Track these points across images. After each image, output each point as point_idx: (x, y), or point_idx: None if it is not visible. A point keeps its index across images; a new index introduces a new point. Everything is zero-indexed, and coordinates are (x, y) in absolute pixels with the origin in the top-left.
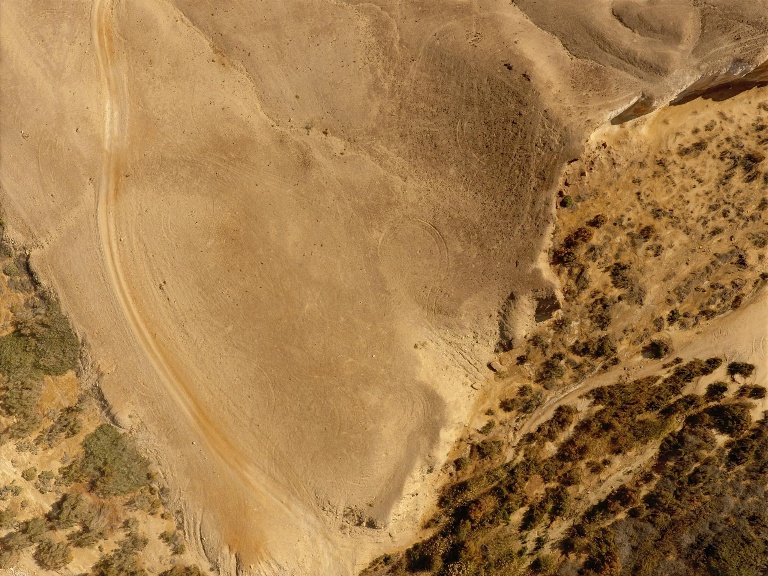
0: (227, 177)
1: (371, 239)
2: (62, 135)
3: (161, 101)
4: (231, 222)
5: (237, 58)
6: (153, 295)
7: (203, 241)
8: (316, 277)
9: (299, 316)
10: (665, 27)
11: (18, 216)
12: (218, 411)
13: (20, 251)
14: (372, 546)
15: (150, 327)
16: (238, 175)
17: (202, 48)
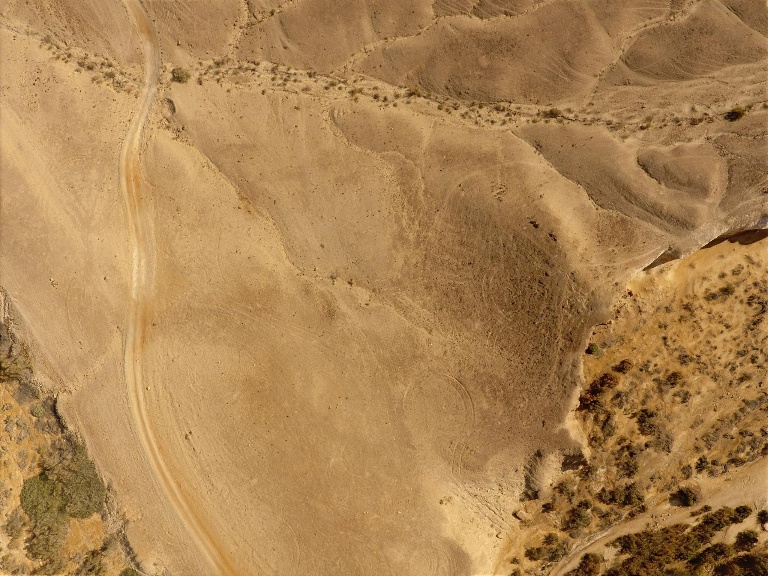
0: (253, 327)
1: (396, 392)
2: (90, 283)
3: (188, 249)
4: (257, 374)
5: (263, 205)
6: (179, 444)
7: (229, 393)
8: (341, 431)
9: (324, 471)
10: (692, 180)
11: (46, 361)
12: (243, 562)
13: (48, 394)
14: None
15: (176, 476)
16: (264, 325)
17: (228, 194)
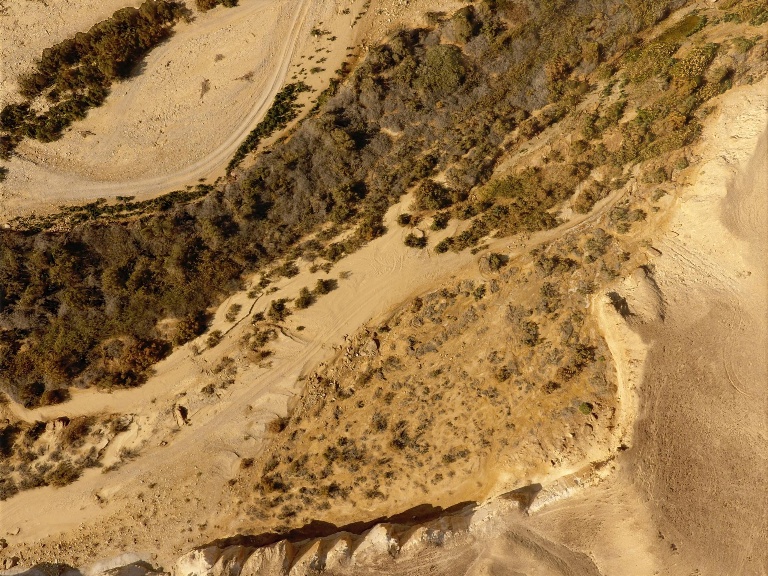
0: None
1: None
2: None
3: None
4: None
5: None
6: None
7: None
8: None
9: None
10: None
11: None
12: None
13: None
14: (764, 93)
15: None
16: None
17: None
